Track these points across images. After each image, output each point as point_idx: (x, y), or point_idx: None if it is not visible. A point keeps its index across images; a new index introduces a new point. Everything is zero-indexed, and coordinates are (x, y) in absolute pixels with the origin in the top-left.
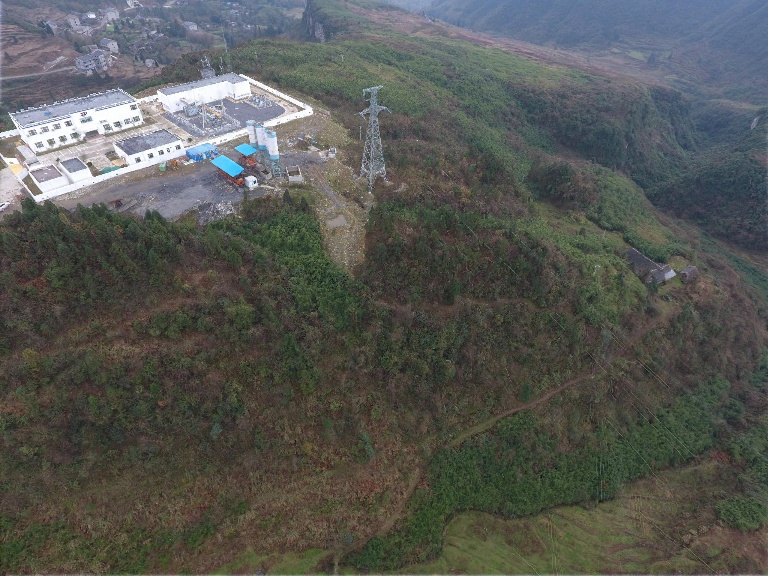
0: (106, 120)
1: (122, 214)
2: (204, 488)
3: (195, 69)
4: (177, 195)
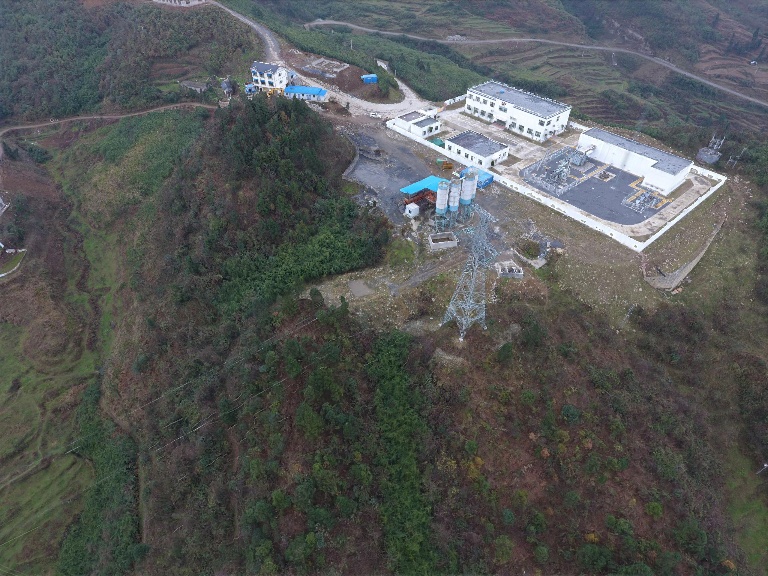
0: (516, 119)
1: (338, 150)
2: (155, 274)
3: (706, 144)
4: (394, 176)
